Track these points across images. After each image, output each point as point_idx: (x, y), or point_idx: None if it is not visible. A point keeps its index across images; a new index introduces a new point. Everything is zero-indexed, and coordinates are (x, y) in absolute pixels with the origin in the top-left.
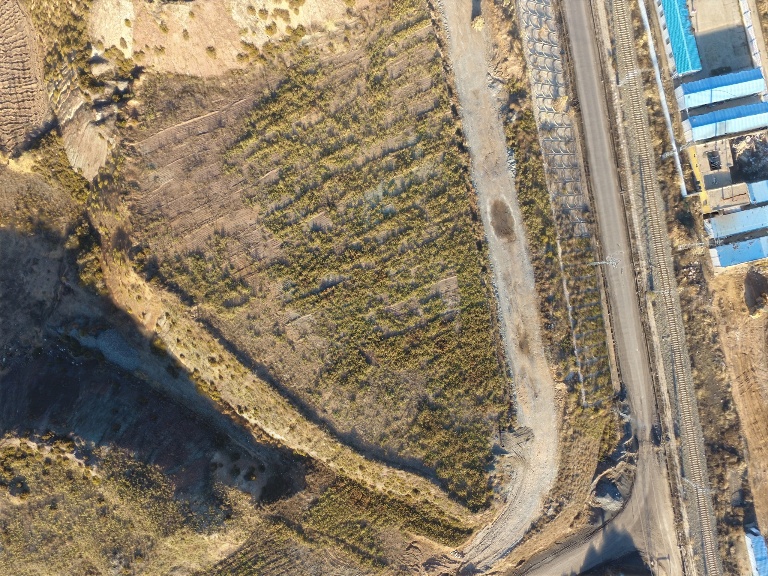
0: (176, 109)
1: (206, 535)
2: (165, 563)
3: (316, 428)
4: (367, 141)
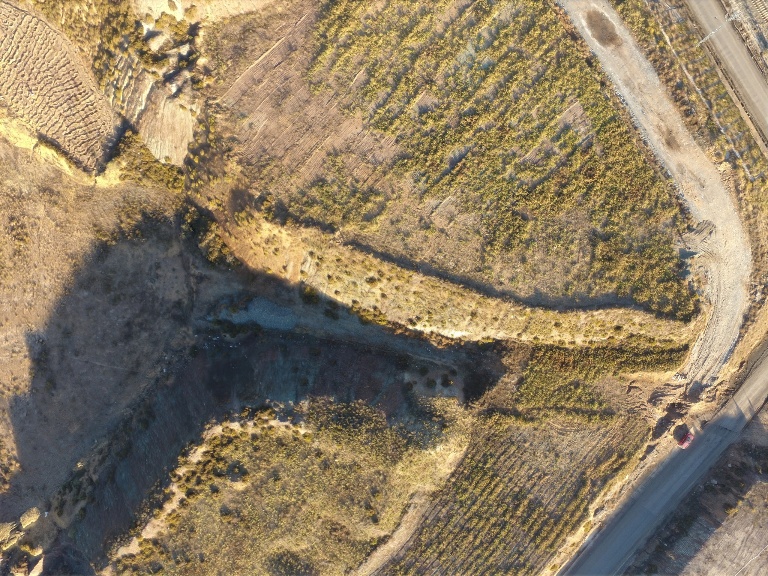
0: (244, 51)
1: (432, 449)
2: (402, 492)
3: (500, 302)
4: (439, 6)
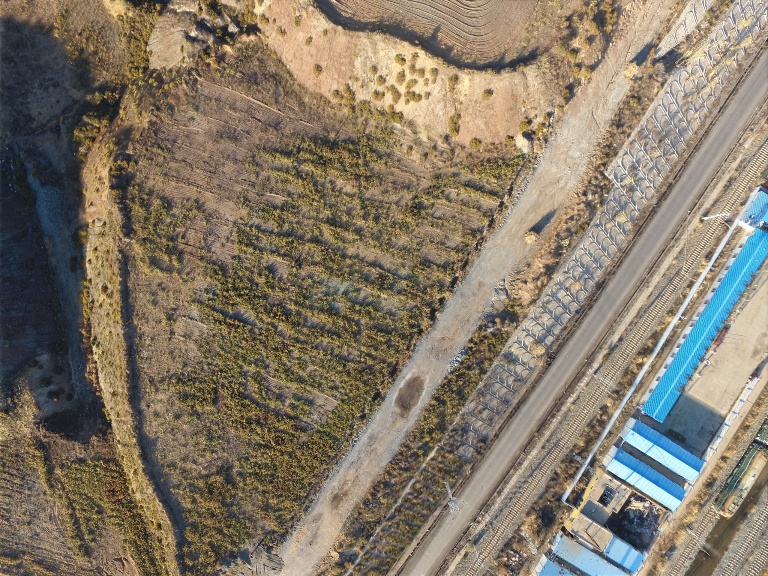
0: (255, 83)
1: None
2: None
3: (129, 412)
4: (370, 242)
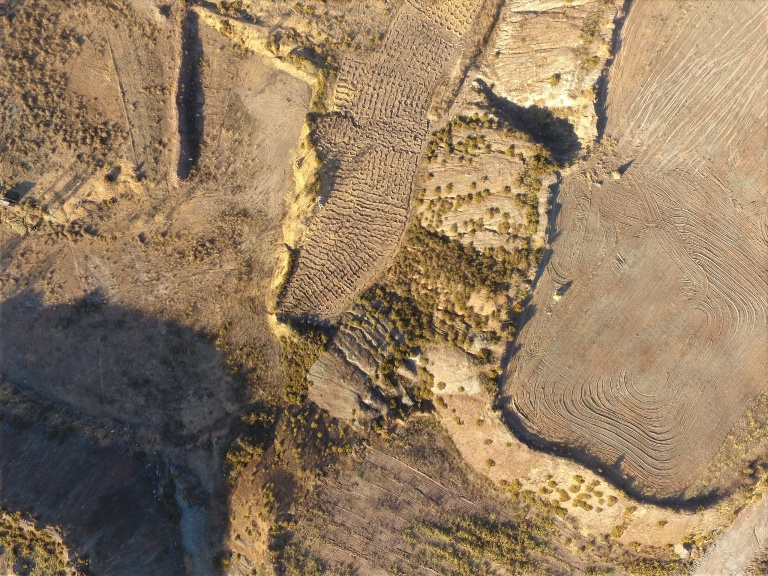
0: (422, 457)
1: None
2: None
3: None
4: None
